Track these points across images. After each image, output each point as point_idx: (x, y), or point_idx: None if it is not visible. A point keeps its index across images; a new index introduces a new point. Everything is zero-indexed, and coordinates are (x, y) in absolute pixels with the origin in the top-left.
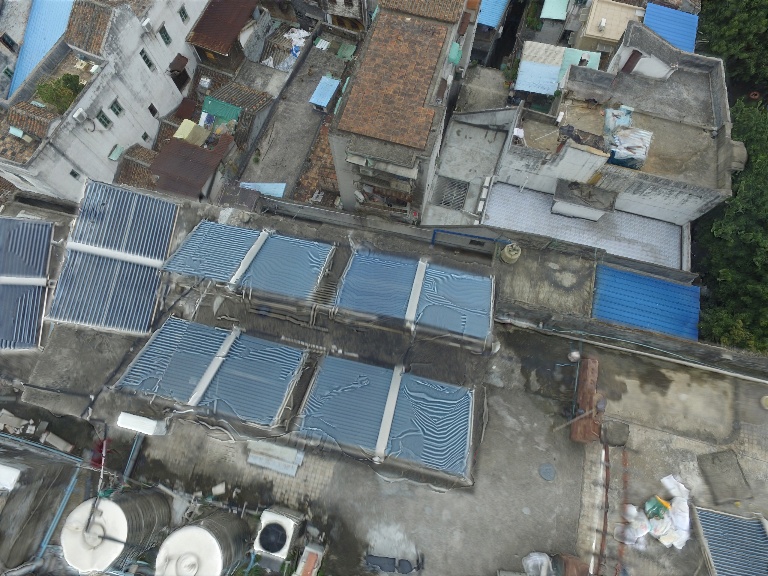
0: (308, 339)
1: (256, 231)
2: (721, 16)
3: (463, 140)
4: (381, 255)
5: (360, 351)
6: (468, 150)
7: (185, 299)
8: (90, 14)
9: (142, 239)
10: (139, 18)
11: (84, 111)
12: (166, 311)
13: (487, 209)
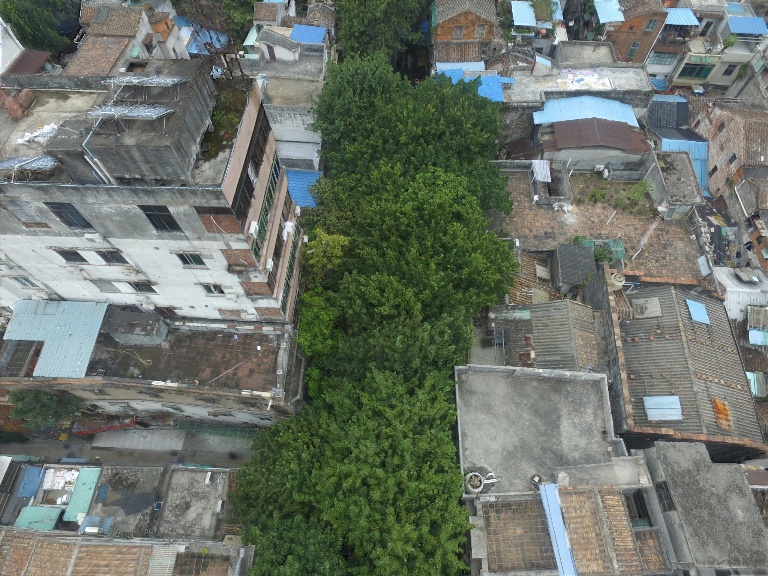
0: None
1: None
2: None
3: None
4: None
5: None
6: None
7: None
8: None
9: None
10: None
11: None
12: None
13: None
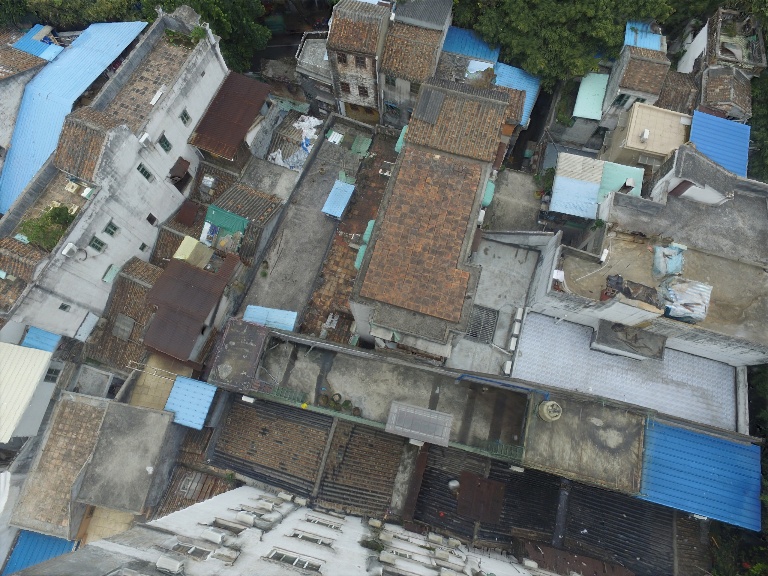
0: None
1: None
2: None
3: (491, 260)
4: None
5: None
6: (497, 272)
7: None
8: (82, 137)
9: None
10: (136, 134)
11: (75, 243)
12: None
13: None
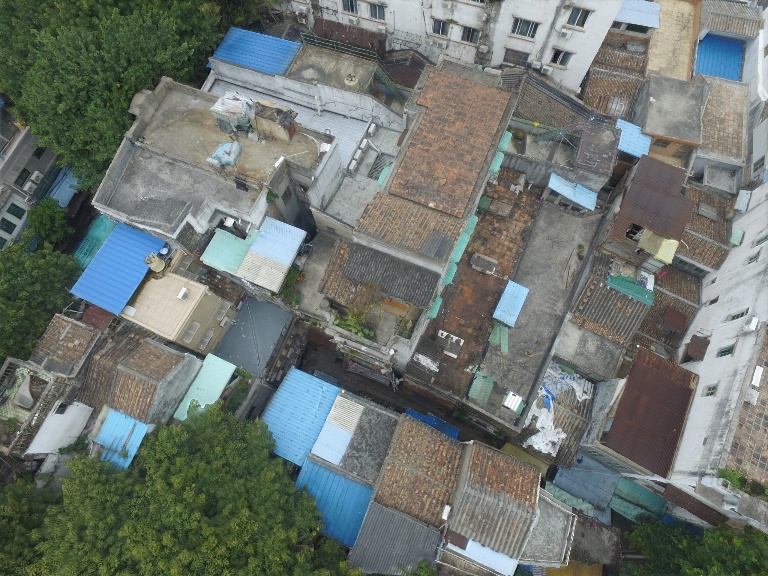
0: None
1: None
2: (40, 298)
3: None
4: None
5: None
6: (362, 208)
7: None
8: None
9: None
10: (765, 325)
11: None
12: None
13: None
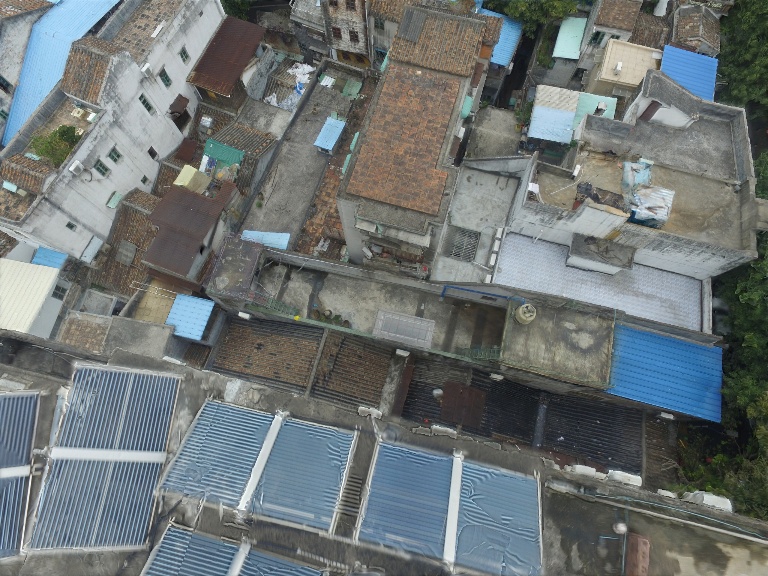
0: (328, 554)
1: (267, 415)
2: (741, 59)
3: (474, 187)
4: (409, 441)
5: (387, 566)
6: (479, 198)
7: (187, 498)
8: (87, 62)
9: (138, 429)
10: (138, 63)
11: (81, 162)
12: (165, 512)
13: (499, 261)
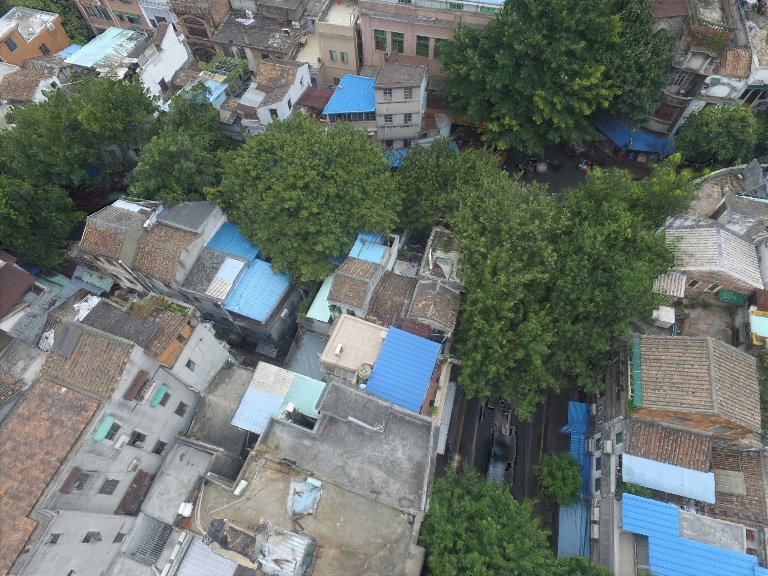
0: None
1: None
2: None
3: (184, 467)
4: None
5: None
6: (186, 481)
7: None
8: None
9: None
10: None
11: None
12: None
13: (180, 568)
